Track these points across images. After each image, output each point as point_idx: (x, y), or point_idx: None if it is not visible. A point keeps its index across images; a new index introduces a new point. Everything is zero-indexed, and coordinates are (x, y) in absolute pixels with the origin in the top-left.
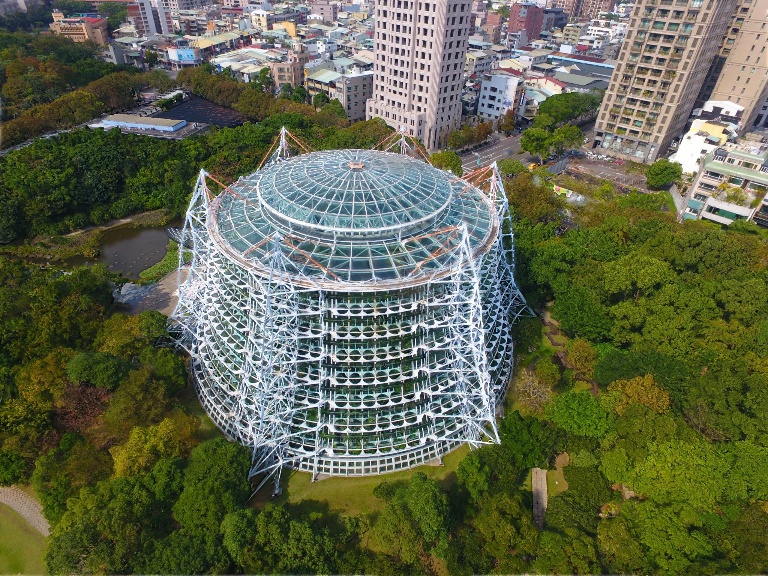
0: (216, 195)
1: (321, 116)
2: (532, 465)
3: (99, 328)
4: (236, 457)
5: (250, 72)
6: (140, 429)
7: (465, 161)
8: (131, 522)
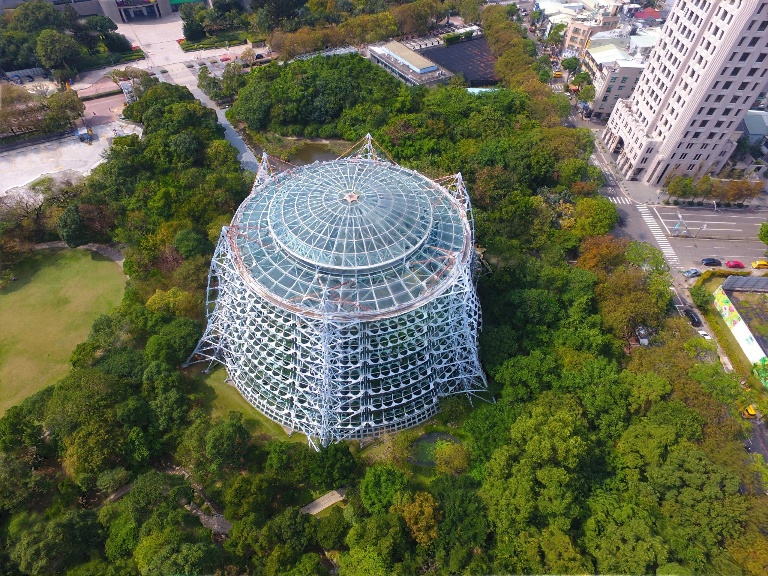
0: (376, 151)
1: (539, 105)
2: (313, 483)
3: (215, 218)
4: (186, 337)
5: (555, 22)
6: (175, 289)
7: (677, 216)
8: (126, 331)
